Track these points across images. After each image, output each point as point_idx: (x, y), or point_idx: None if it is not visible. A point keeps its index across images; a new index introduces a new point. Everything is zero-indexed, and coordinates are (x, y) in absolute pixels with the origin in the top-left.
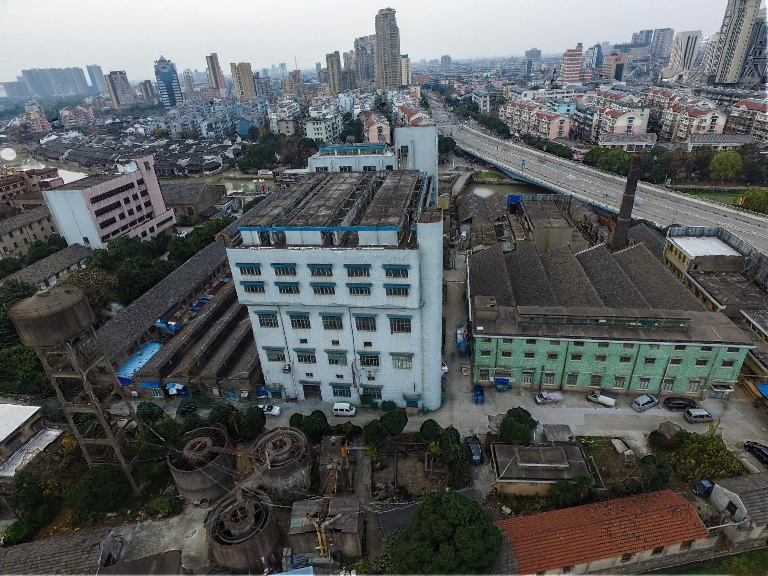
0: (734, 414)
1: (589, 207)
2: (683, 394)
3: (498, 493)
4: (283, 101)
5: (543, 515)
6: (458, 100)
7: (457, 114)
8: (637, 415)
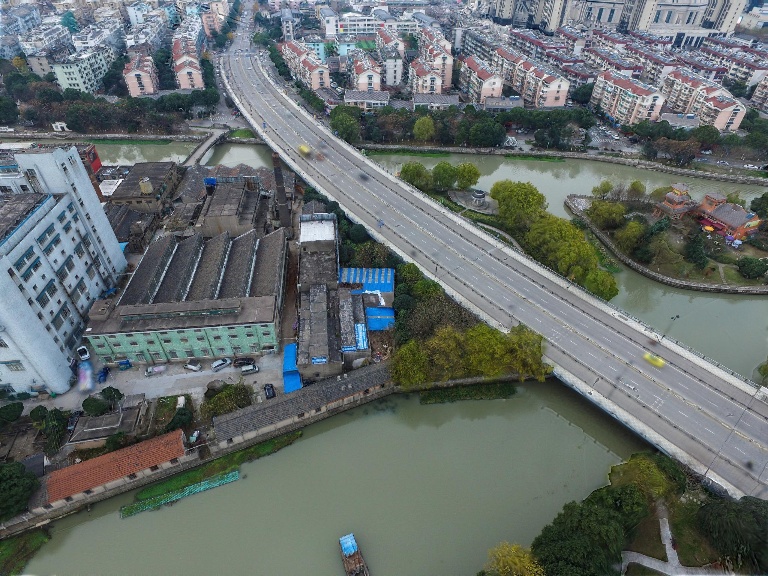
0: (275, 364)
1: (292, 179)
2: (250, 354)
3: (76, 450)
4: (48, 18)
5: (86, 462)
6: (267, 20)
7: (256, 42)
8: (213, 374)
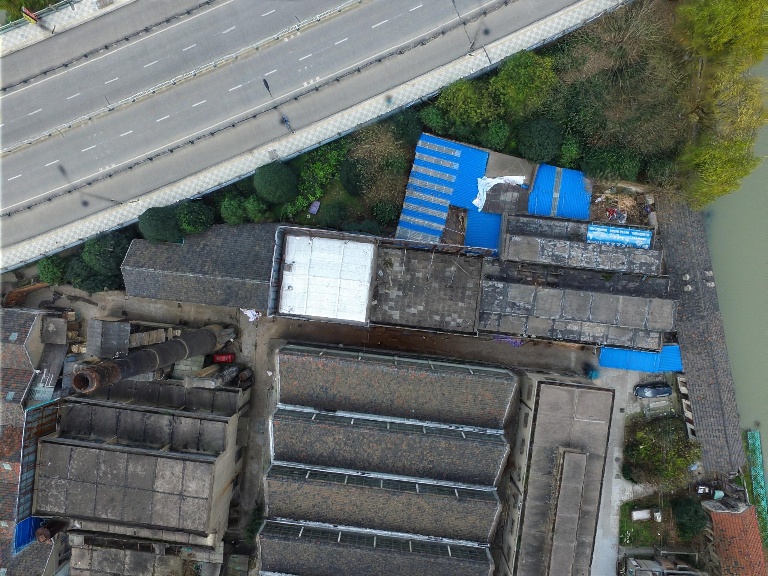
0: (595, 379)
1: None
2: None
3: None
4: None
5: None
6: None
7: None
8: None
